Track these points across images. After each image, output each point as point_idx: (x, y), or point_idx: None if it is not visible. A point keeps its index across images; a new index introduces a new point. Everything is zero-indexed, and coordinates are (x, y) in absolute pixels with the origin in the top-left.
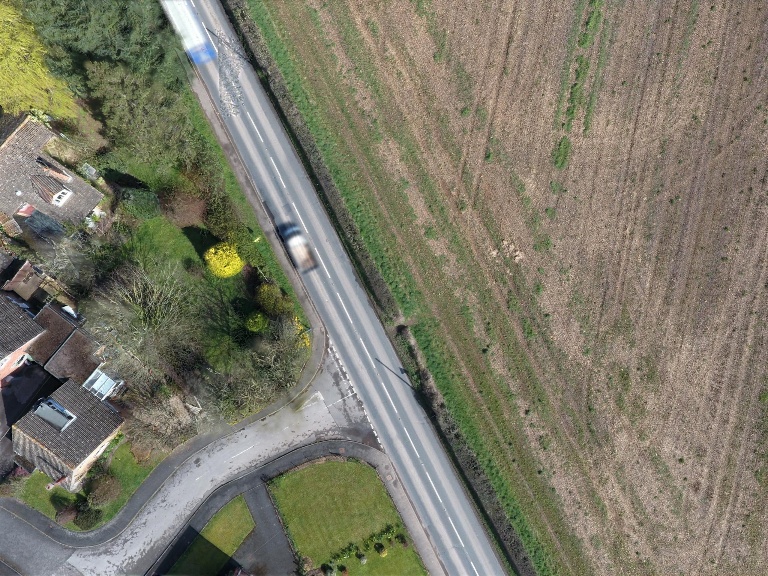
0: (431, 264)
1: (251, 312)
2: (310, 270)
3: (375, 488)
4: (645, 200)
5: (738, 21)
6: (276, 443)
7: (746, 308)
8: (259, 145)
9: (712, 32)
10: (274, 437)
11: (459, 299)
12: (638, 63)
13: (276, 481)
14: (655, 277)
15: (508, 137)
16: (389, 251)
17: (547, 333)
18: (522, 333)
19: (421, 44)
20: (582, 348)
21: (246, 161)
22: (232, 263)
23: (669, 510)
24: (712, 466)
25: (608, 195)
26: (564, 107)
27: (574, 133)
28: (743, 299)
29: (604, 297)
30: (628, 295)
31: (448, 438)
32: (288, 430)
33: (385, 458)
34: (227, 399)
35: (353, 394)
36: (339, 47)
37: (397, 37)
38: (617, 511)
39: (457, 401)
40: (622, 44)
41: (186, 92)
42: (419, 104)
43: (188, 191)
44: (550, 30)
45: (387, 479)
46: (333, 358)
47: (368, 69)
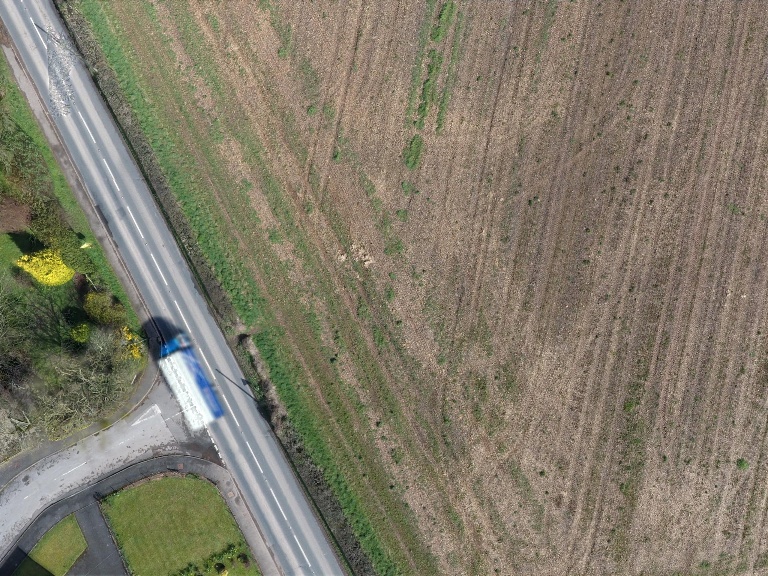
0: (276, 270)
1: (78, 322)
2: (146, 277)
3: (216, 505)
4: (502, 201)
5: (600, 13)
6: (110, 459)
7: (610, 313)
8: (91, 146)
9: (572, 24)
10: (108, 453)
11: (305, 306)
12: (494, 57)
13: (109, 499)
14: (513, 281)
15: (357, 136)
16: (230, 256)
17: (399, 341)
18: (373, 341)
19: (265, 39)
20: (436, 356)
21: (78, 163)
22: (55, 271)
23: (530, 525)
24: (575, 479)
25: (463, 196)
26: (416, 104)
27: (427, 131)
28: (606, 304)
29: (459, 303)
30: (485, 300)
31: (289, 453)
32: (123, 445)
33: (226, 474)
34: (51, 414)
35: (192, 407)
36: (177, 43)
37: (239, 32)
38: (475, 527)
39: (303, 413)
40: (477, 38)
41: (12, 91)
42: (263, 102)
43: (17, 195)
44: (401, 23)
45: (228, 496)
46: (171, 369)
47: (208, 66)
